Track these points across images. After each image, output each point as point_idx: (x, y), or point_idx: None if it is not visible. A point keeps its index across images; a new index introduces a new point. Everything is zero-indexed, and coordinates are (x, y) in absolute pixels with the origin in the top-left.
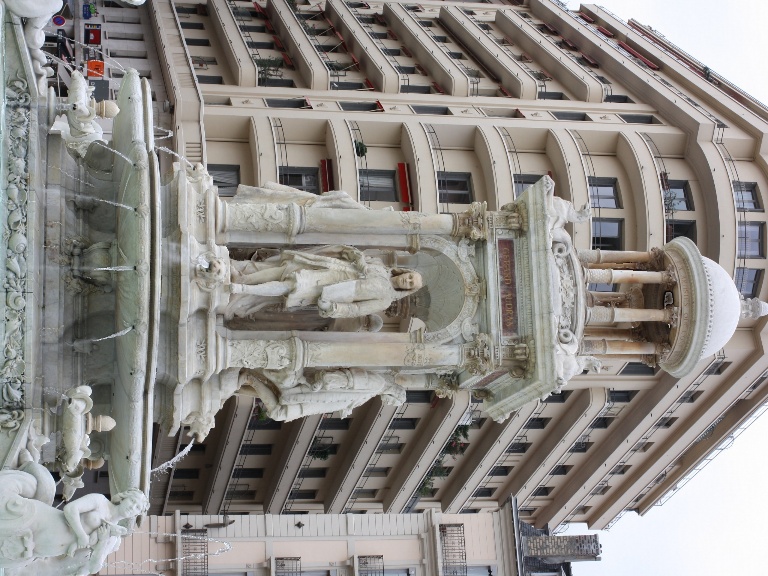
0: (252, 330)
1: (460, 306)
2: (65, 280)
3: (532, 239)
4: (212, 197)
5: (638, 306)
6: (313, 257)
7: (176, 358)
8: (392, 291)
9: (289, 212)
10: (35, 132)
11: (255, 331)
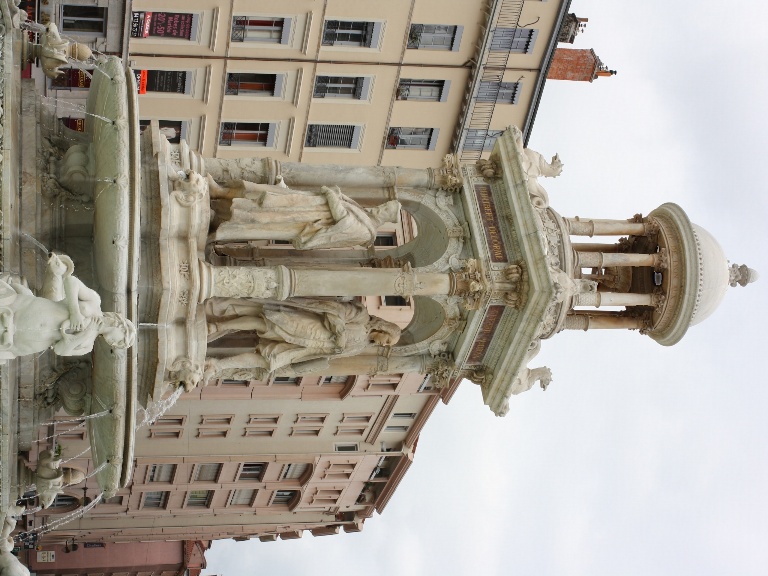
0: (224, 347)
1: (437, 320)
2: (39, 409)
3: (521, 324)
4: (197, 290)
5: (622, 288)
6: (293, 332)
7: (145, 399)
8: (367, 347)
9: (277, 293)
10: (7, 387)
11: (227, 348)
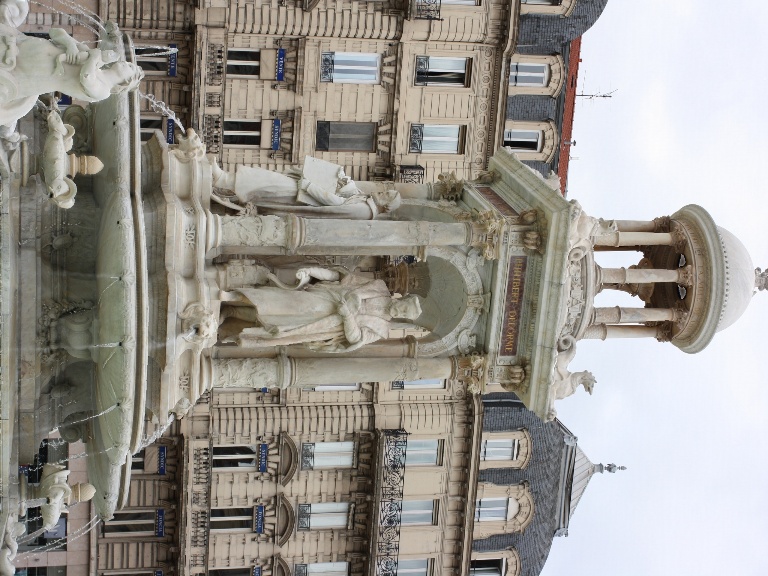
0: None
1: None
2: None
3: None
4: None
5: None
6: None
7: None
8: None
9: None
10: None
11: None
